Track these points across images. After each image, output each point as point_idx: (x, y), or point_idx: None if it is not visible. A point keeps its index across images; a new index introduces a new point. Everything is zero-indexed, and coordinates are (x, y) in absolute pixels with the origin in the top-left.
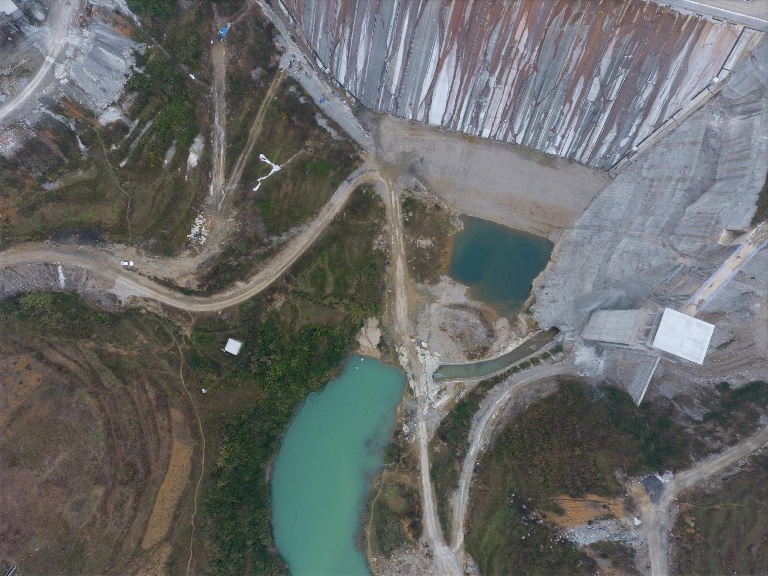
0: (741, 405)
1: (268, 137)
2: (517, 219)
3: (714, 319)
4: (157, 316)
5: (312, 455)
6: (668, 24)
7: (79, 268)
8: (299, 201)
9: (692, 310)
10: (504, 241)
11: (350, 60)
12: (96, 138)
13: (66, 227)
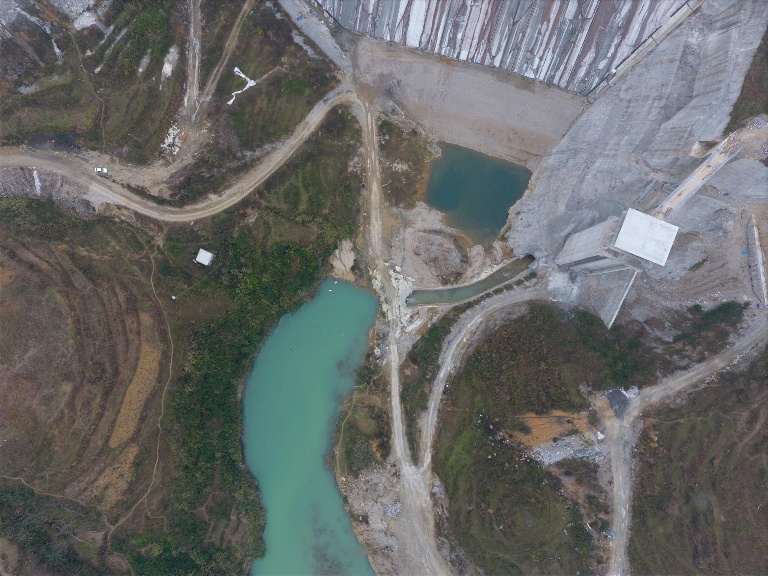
0: (712, 325)
1: (243, 51)
2: (495, 146)
3: (687, 240)
4: (130, 225)
5: (284, 376)
6: None
7: (54, 173)
8: (274, 117)
9: (659, 218)
10: (482, 169)
11: None
12: (71, 43)
13: (41, 132)
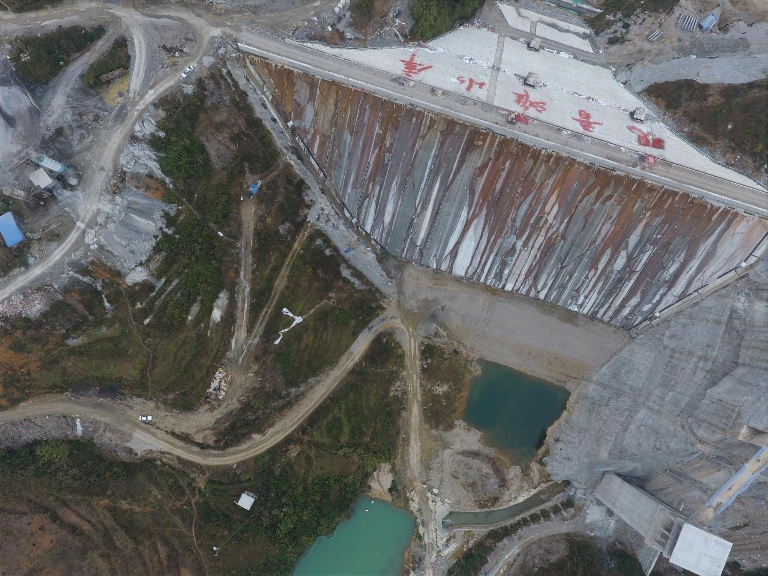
0: None
1: (292, 290)
2: (535, 367)
3: None
4: (172, 467)
5: None
6: (699, 212)
7: (97, 421)
8: (319, 352)
9: (709, 513)
10: (520, 386)
11: (378, 213)
12: (122, 297)
13: (87, 381)
